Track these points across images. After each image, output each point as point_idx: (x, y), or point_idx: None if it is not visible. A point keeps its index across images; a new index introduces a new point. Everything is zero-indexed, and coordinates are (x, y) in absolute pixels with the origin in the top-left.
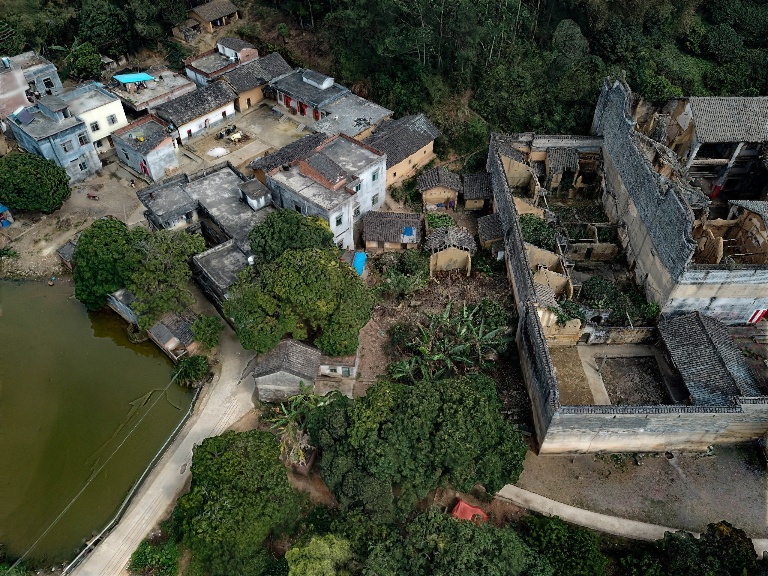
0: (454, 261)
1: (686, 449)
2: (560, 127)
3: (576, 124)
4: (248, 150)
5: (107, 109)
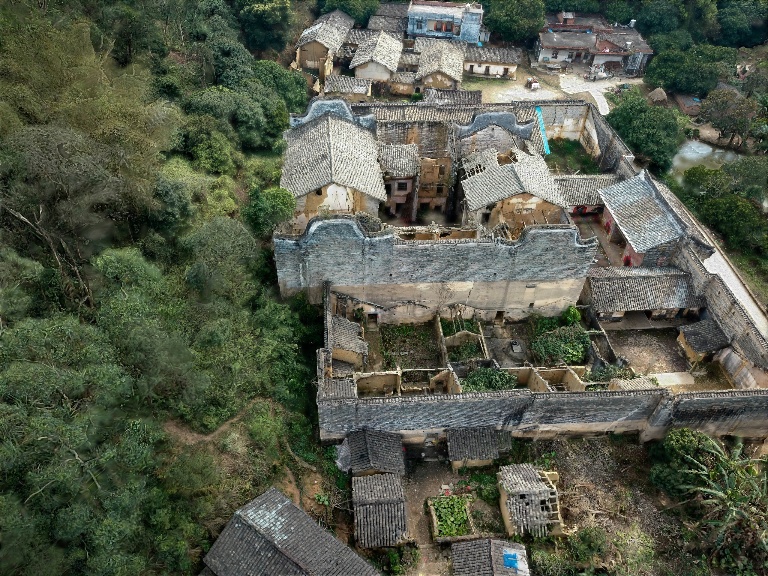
0: None
1: None
2: (282, 323)
3: None
4: None
5: None
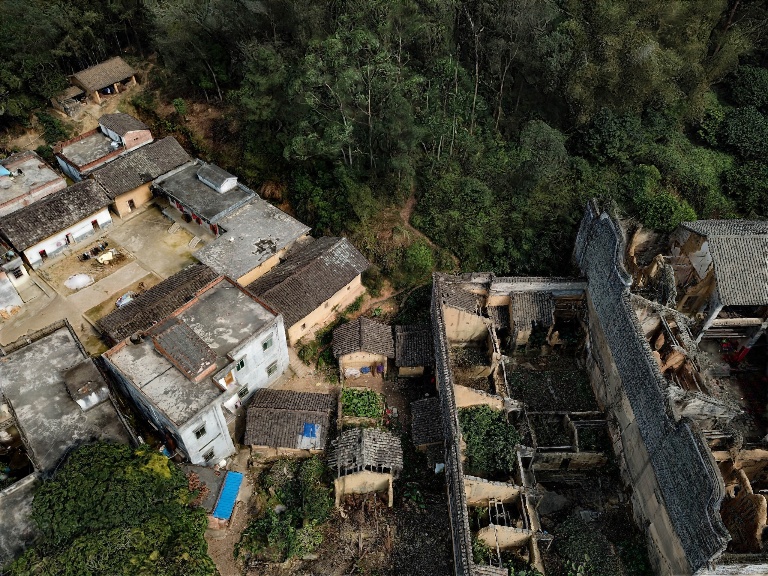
0: (370, 484)
1: None
2: (530, 256)
3: (552, 251)
4: (119, 278)
5: None
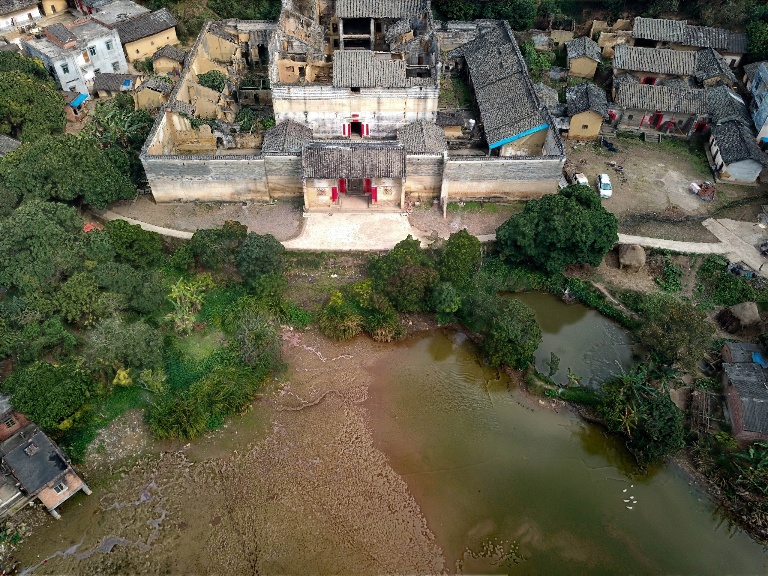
0: (152, 101)
1: (255, 199)
2: (267, 18)
3: None
4: None
5: None
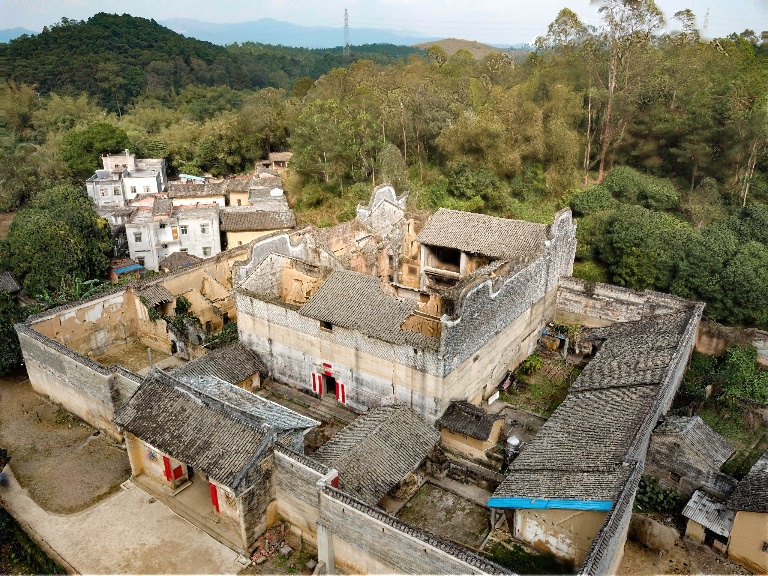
0: None
1: (108, 432)
2: None
3: None
4: None
5: (145, 181)
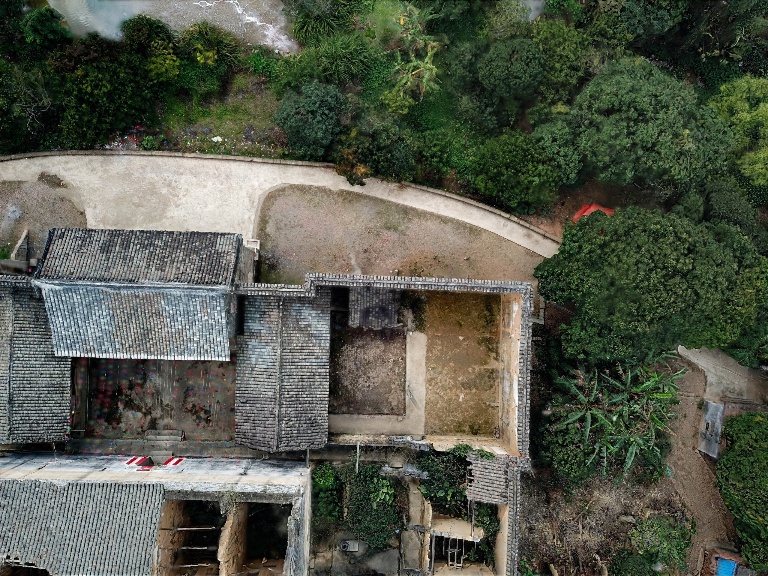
0: None
1: None
2: None
3: None
4: None
5: None
